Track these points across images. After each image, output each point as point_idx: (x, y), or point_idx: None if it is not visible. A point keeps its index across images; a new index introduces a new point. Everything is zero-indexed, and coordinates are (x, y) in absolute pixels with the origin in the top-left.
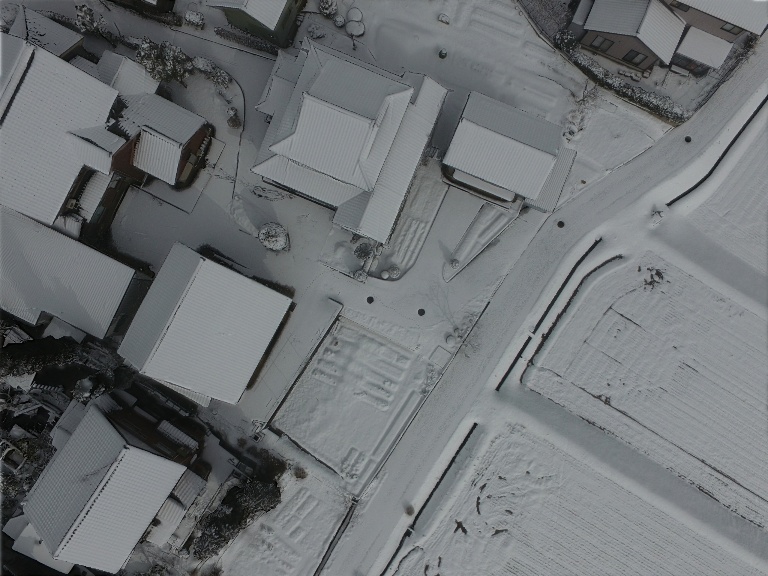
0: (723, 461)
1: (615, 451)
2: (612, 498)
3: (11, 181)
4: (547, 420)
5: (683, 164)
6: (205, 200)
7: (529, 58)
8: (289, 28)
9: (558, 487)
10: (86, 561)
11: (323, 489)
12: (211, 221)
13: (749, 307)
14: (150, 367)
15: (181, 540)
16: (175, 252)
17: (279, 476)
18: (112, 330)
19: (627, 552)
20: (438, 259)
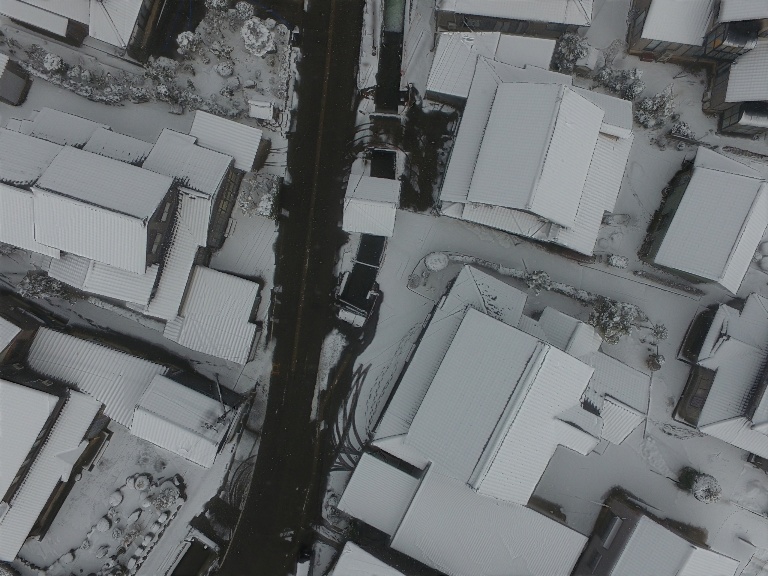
0: None
1: None
2: None
3: (508, 475)
4: None
5: None
6: None
7: None
8: None
9: None
10: None
11: None
12: (622, 462)
13: None
14: None
15: None
16: (647, 530)
17: None
18: None
19: None
20: None
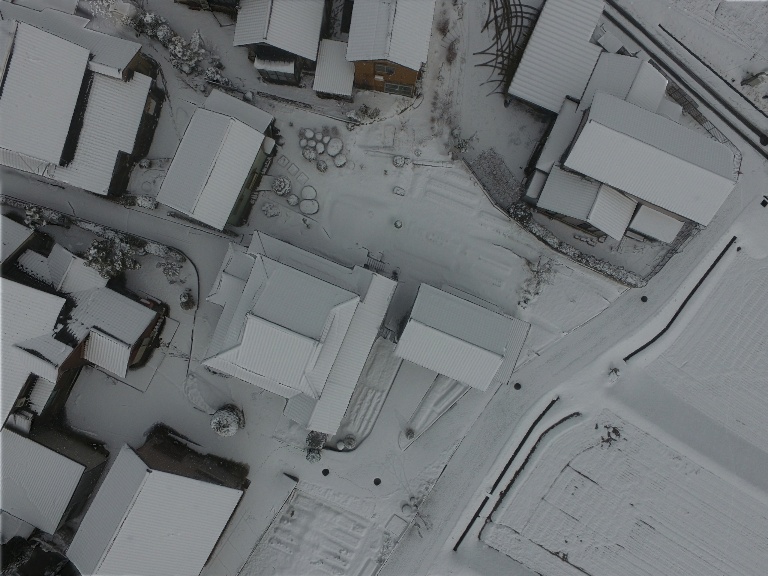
0: None
1: None
2: None
3: None
4: None
5: (639, 324)
6: (159, 378)
7: (484, 227)
8: (243, 208)
9: None
10: None
11: None
12: (165, 399)
13: (705, 465)
14: None
15: None
16: (123, 456)
17: None
18: (63, 521)
19: None
20: (394, 428)
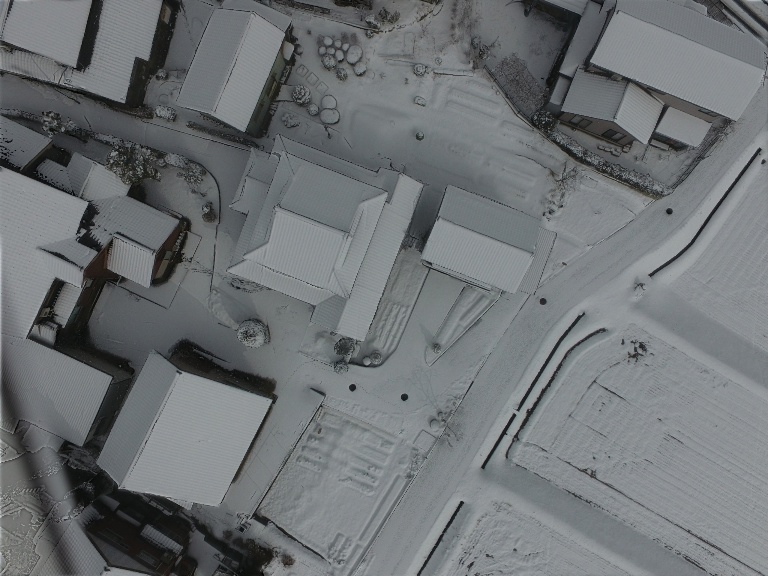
0: (709, 531)
1: (601, 525)
2: (599, 573)
3: None
4: (533, 497)
5: (665, 236)
6: (183, 294)
7: (507, 137)
8: (262, 118)
9: (545, 563)
10: None
11: (311, 574)
12: (189, 315)
13: (733, 378)
14: (129, 481)
15: None
16: (151, 362)
17: (266, 565)
18: (92, 435)
19: None
20: (420, 343)
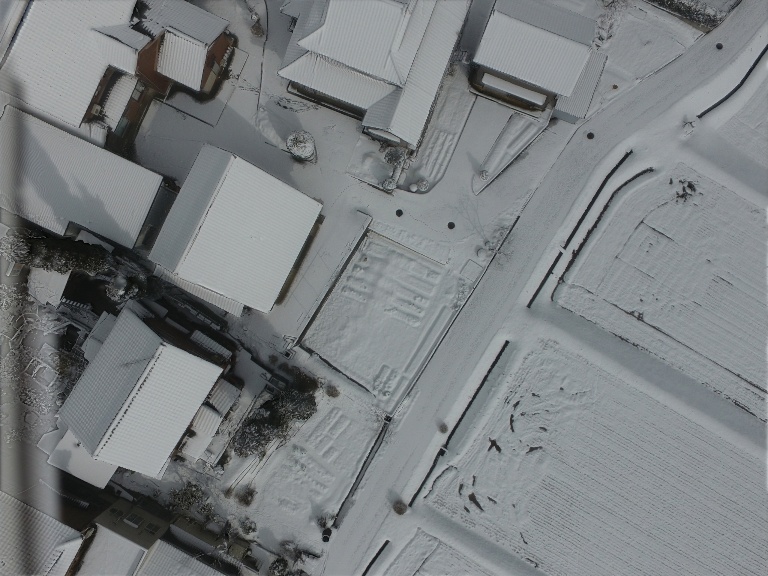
0: (759, 375)
1: (650, 366)
2: (648, 412)
3: (37, 79)
4: (580, 335)
5: (715, 72)
6: (229, 113)
7: None
8: None
9: (592, 403)
10: (125, 463)
11: (355, 408)
12: (236, 134)
13: None
14: (183, 269)
15: (215, 456)
16: (204, 154)
17: (311, 394)
18: (141, 241)
19: (664, 466)
20: (467, 171)
